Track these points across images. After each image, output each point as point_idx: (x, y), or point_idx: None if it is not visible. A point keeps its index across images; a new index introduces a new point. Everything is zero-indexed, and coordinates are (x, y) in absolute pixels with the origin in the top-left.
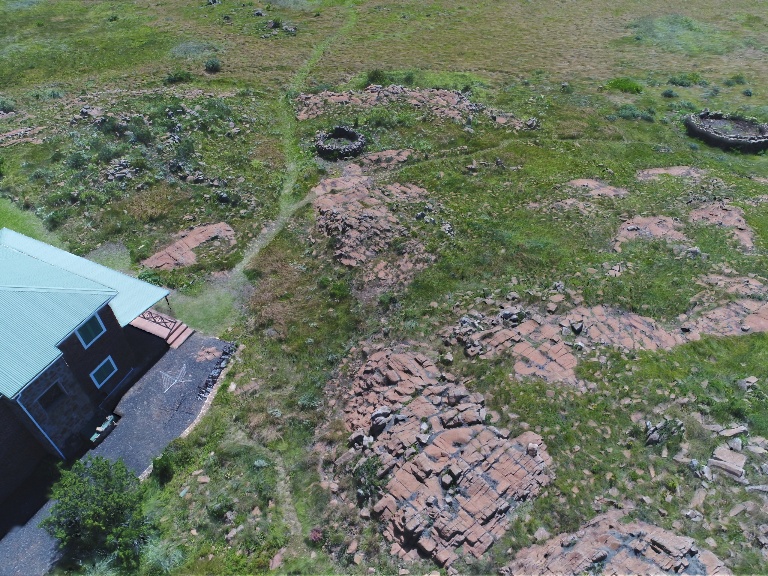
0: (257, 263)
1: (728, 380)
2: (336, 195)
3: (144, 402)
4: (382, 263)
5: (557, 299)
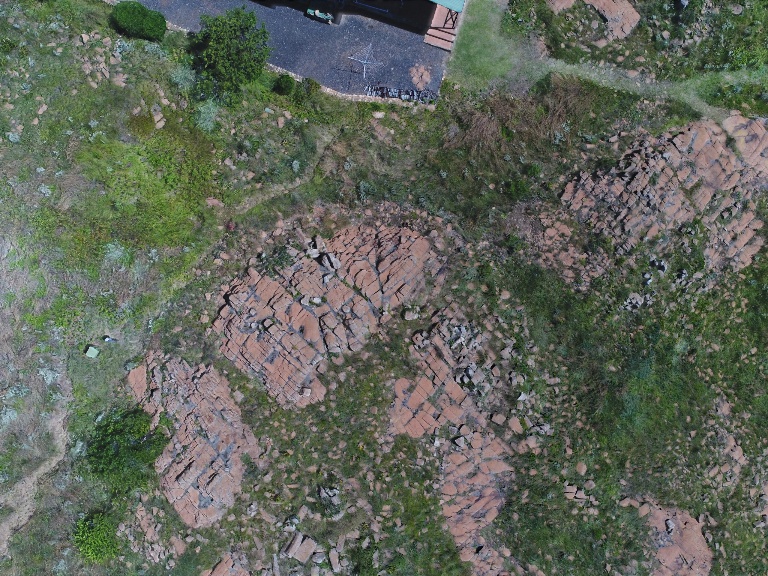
0: (559, 85)
1: (406, 573)
2: (718, 147)
3: (357, 38)
4: (568, 230)
5: (513, 425)
